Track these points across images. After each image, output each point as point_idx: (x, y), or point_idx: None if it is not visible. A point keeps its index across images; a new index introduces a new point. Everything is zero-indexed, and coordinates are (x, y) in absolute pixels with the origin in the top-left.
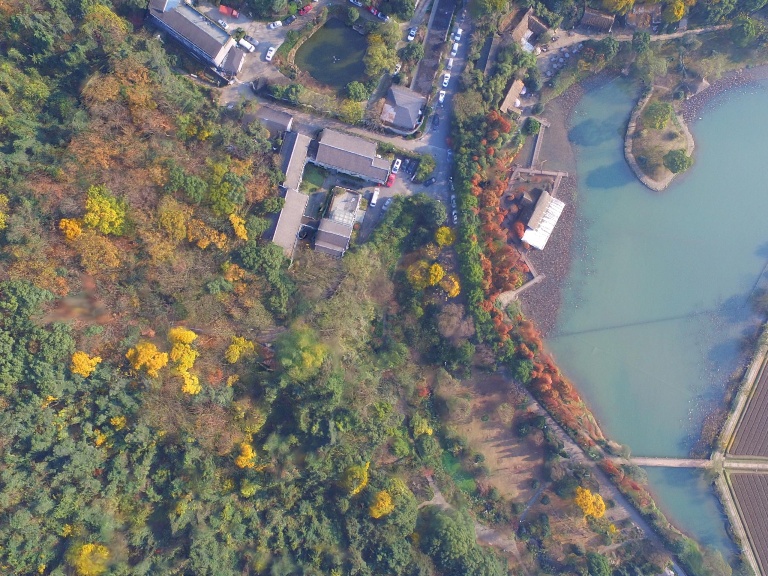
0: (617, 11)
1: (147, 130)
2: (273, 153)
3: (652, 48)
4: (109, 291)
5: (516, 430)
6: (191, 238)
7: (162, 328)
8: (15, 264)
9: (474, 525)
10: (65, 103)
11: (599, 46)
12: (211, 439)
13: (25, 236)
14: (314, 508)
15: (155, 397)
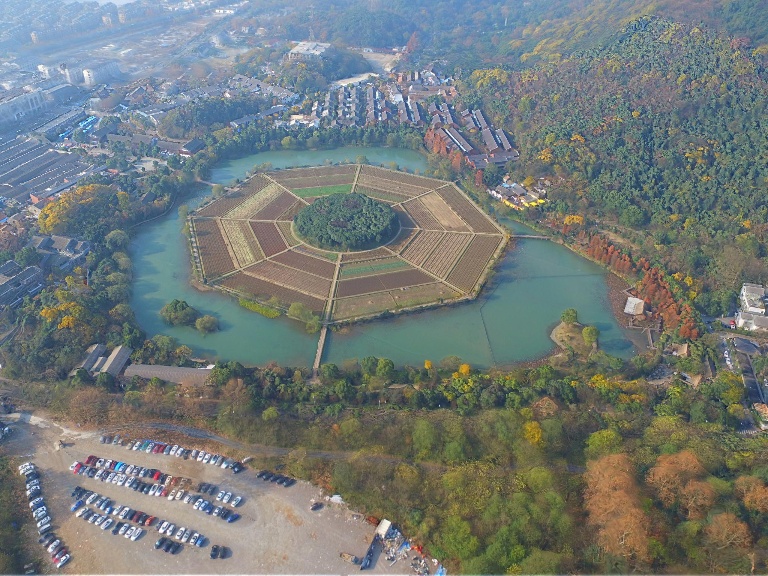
0: None
1: None
2: None
3: None
4: None
5: None
6: None
7: None
8: None
9: None
10: None
11: None
12: None
13: None
14: None
15: None
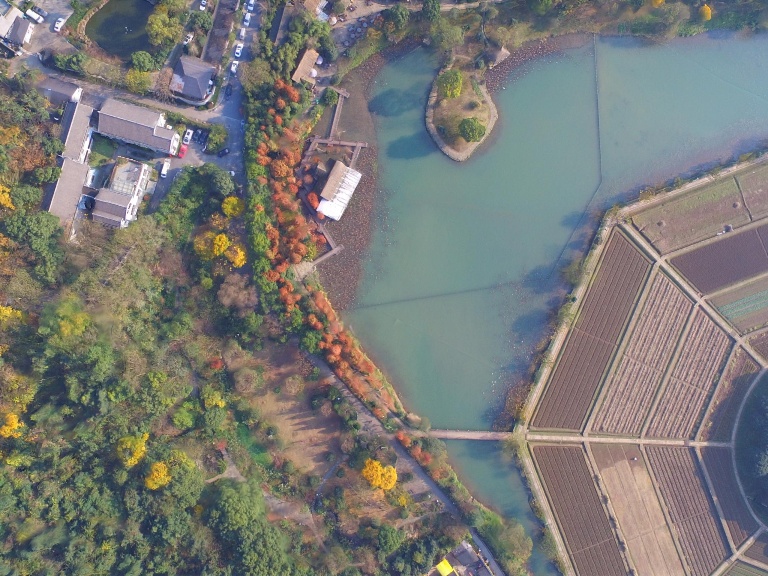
0: None
1: None
2: (53, 123)
3: (448, 17)
4: None
5: (310, 402)
6: None
7: None
8: None
9: (268, 498)
10: None
11: (389, 14)
12: None
13: None
14: (94, 480)
15: None
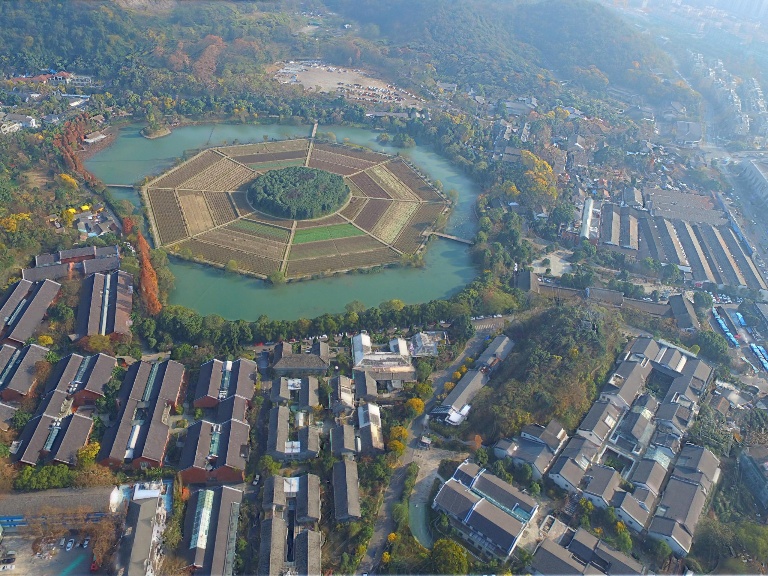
0: None
1: None
2: None
3: None
4: None
5: None
6: None
7: None
8: None
9: None
10: None
11: None
12: None
13: None
14: None
15: None
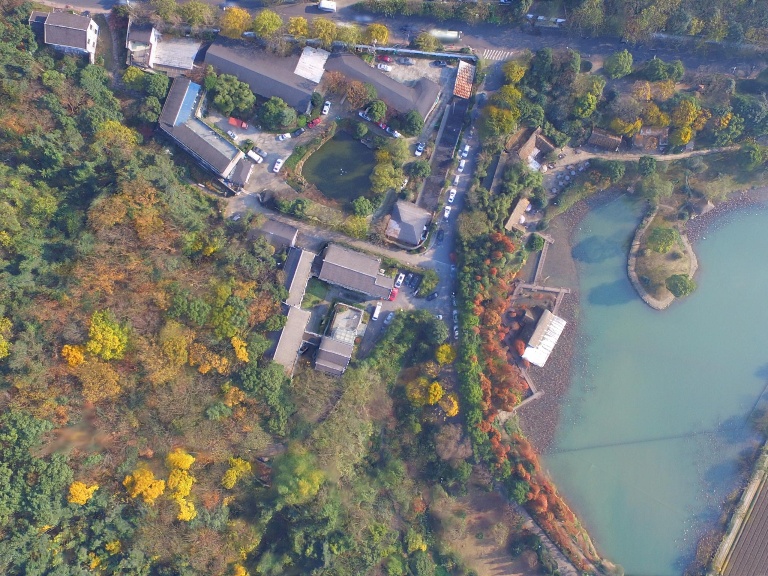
0: (624, 133)
1: (153, 244)
2: (277, 269)
3: (658, 170)
4: (109, 419)
5: (510, 548)
6: (192, 363)
7: (160, 447)
8: (16, 395)
9: None
10: (72, 219)
11: (605, 169)
12: (205, 562)
13: (27, 365)
14: None
15: (151, 523)
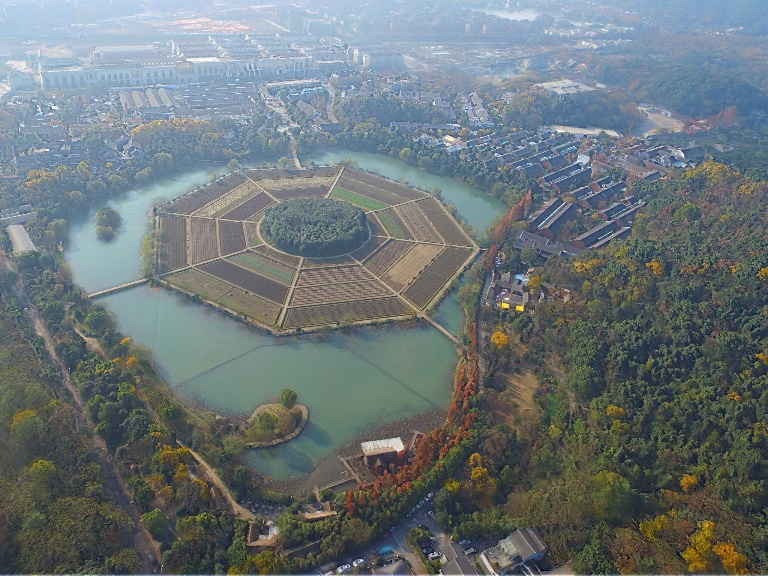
0: None
1: None
2: None
3: None
4: None
5: None
6: None
7: None
8: None
9: None
10: None
11: (246, 479)
12: None
13: None
14: None
15: None
